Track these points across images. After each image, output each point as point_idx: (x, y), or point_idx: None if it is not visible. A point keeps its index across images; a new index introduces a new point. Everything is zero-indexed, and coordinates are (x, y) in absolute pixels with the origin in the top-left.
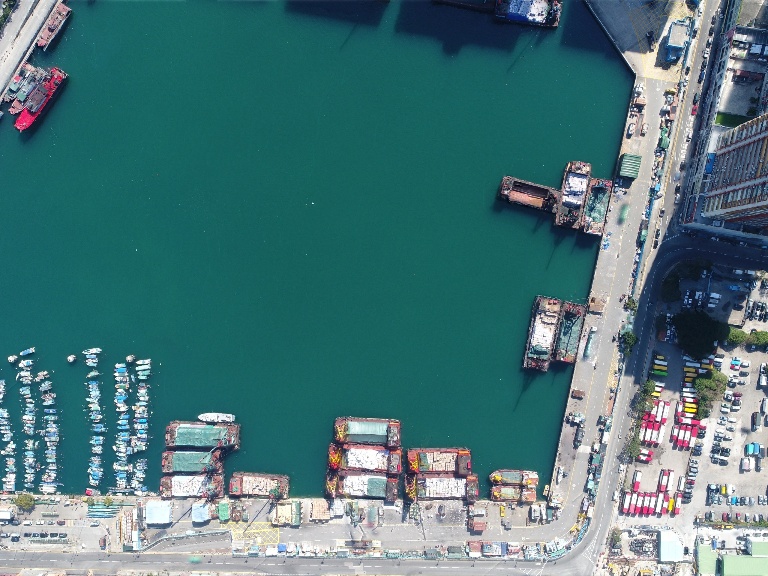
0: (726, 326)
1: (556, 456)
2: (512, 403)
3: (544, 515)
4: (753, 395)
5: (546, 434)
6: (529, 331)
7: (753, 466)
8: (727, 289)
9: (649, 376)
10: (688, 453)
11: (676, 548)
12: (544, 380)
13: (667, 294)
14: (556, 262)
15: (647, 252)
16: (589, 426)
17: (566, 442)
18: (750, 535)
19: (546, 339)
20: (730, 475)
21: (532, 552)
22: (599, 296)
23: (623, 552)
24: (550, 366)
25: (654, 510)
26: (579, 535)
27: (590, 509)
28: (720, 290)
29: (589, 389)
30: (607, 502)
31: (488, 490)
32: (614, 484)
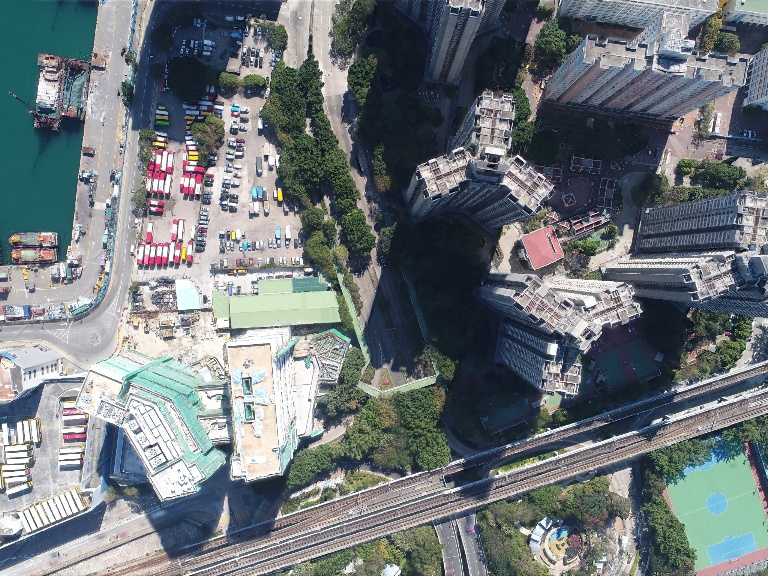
0: (217, 70)
1: (74, 215)
2: (29, 166)
3: (62, 273)
4: (256, 141)
5: (64, 195)
6: (37, 91)
7: (257, 209)
8: (220, 36)
9: (154, 128)
10: (199, 202)
11: (192, 296)
12: (60, 142)
13: (155, 40)
14: (61, 22)
15: (143, 5)
16: (103, 183)
17: (82, 200)
18: (262, 278)
19: (49, 96)
20: (240, 221)
21: (55, 312)
22: (101, 51)
23: (146, 306)
24: (63, 126)
25: (169, 260)
26: (101, 291)
27: (107, 264)
28: (216, 39)
29: (100, 146)
30: (126, 257)
31: (9, 254)
32: (132, 239)
